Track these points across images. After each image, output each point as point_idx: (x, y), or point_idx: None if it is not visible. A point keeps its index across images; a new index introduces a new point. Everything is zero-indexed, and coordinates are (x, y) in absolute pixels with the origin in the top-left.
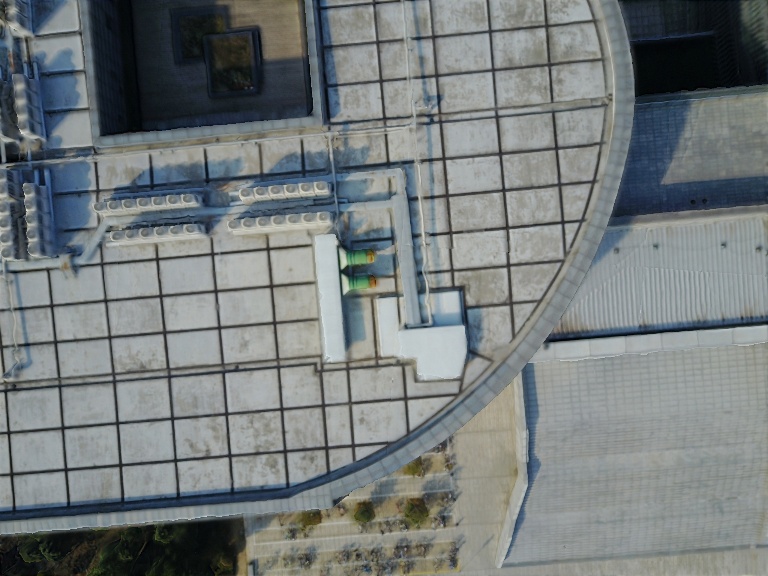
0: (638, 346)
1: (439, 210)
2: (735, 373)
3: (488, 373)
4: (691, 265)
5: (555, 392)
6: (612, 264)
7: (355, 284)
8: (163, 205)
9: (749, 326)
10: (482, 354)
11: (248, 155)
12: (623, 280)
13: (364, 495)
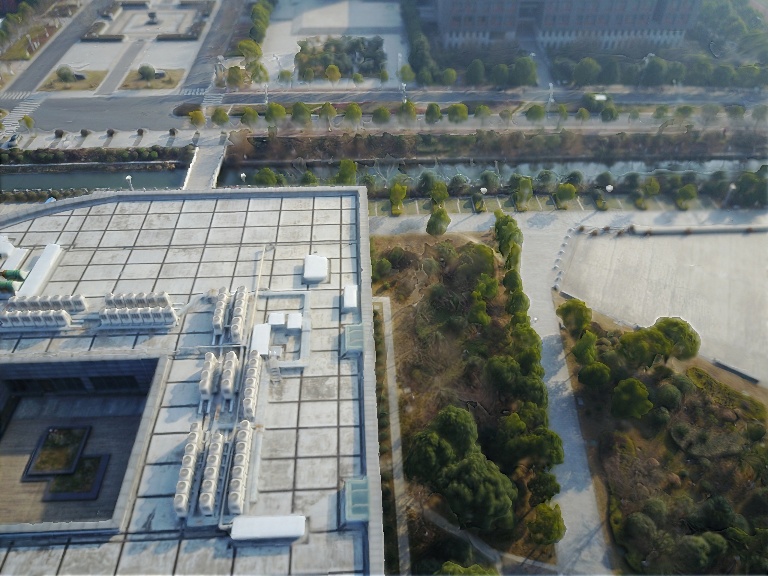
0: None
1: None
2: None
3: None
4: None
5: None
6: None
7: None
8: None
9: None
10: None
11: (56, 350)
12: None
13: None
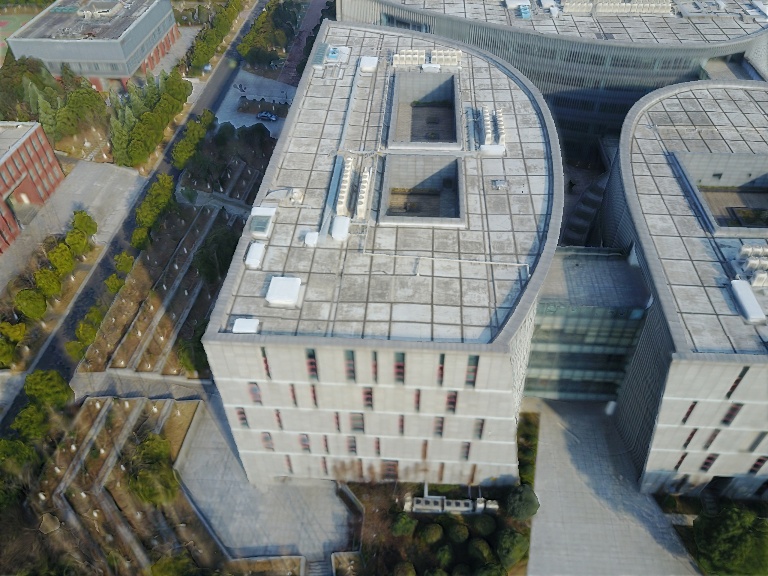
0: None
1: None
2: None
3: None
4: None
5: None
6: None
7: None
8: None
9: None
10: None
11: None
12: None
13: None
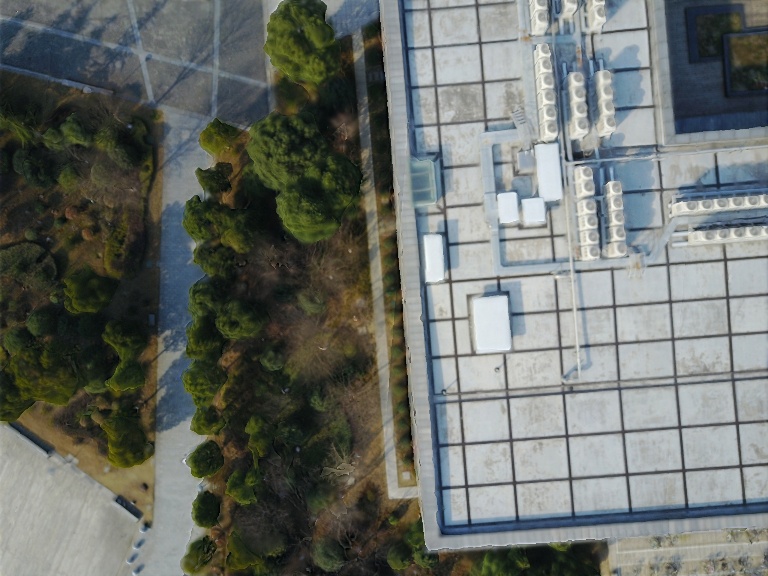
0: None
1: None
2: None
3: None
4: None
5: None
6: None
7: None
8: (755, 205)
9: None
10: None
11: None
12: None
13: None
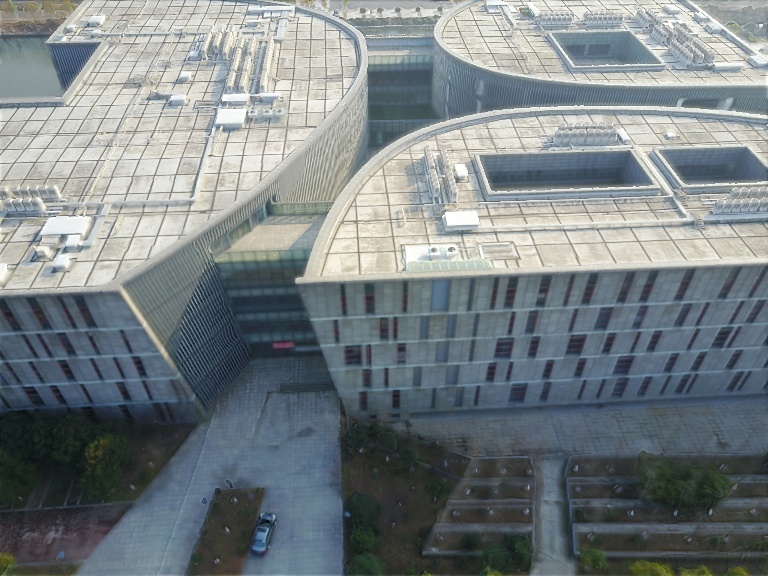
0: None
1: None
2: None
3: (477, 3)
4: None
5: None
6: None
7: None
8: None
9: None
10: None
11: None
12: None
13: None
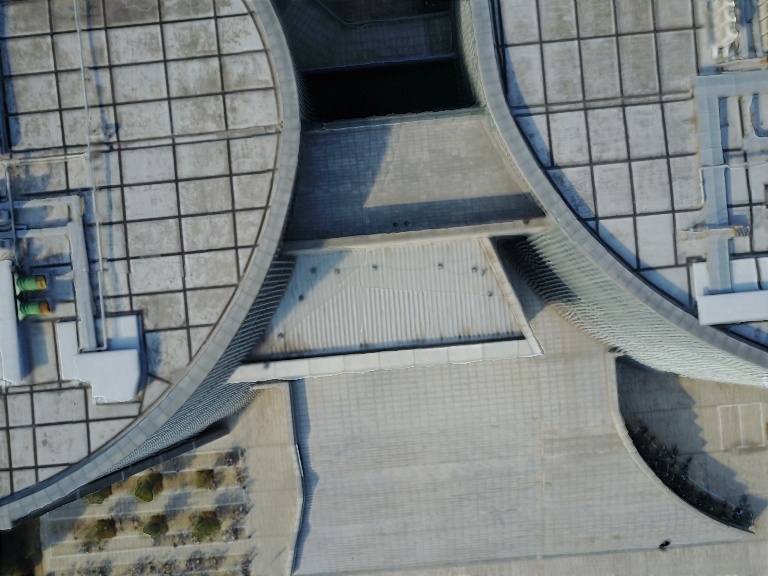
0: (356, 365)
1: (117, 236)
2: (501, 387)
3: (166, 395)
4: (410, 285)
5: (326, 407)
6: (333, 284)
7: (26, 309)
8: None
9: (465, 345)
10: (161, 377)
11: None
12: (344, 300)
13: (158, 508)
